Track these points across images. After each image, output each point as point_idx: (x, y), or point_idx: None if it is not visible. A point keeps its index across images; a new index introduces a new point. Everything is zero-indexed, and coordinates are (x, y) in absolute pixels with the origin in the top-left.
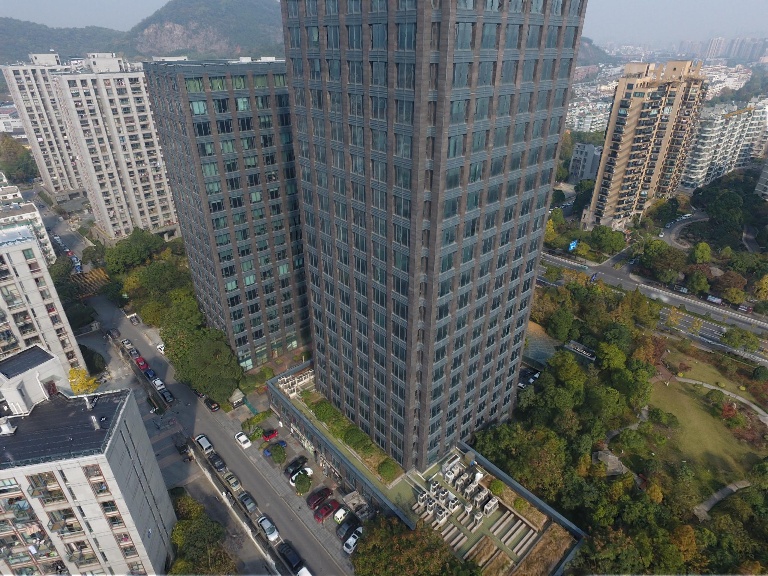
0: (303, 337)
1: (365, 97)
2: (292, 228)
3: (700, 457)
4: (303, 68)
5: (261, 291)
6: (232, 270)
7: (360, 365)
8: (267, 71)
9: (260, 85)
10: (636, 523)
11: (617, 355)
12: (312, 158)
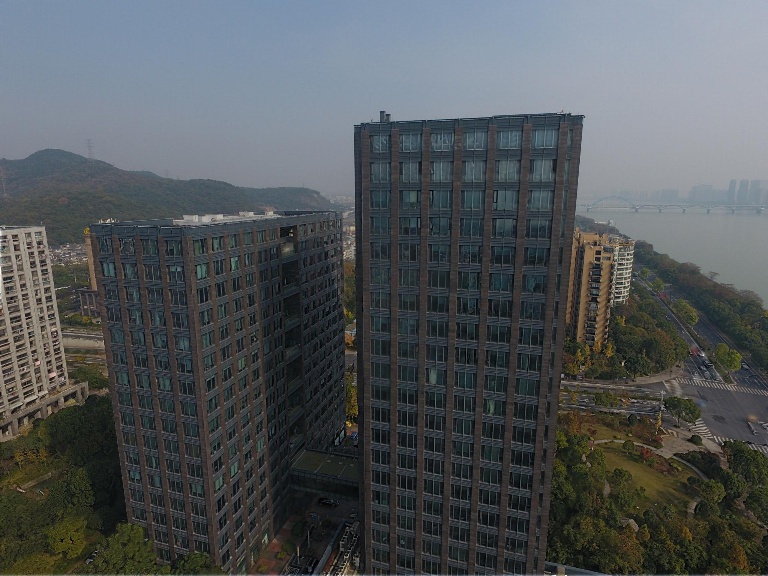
0: (273, 525)
1: (485, 247)
2: (267, 392)
3: (659, 496)
4: (392, 225)
5: (243, 479)
6: (220, 461)
7: (454, 516)
8: (252, 229)
9: (246, 243)
10: (700, 565)
11: (561, 436)
12: (395, 307)
